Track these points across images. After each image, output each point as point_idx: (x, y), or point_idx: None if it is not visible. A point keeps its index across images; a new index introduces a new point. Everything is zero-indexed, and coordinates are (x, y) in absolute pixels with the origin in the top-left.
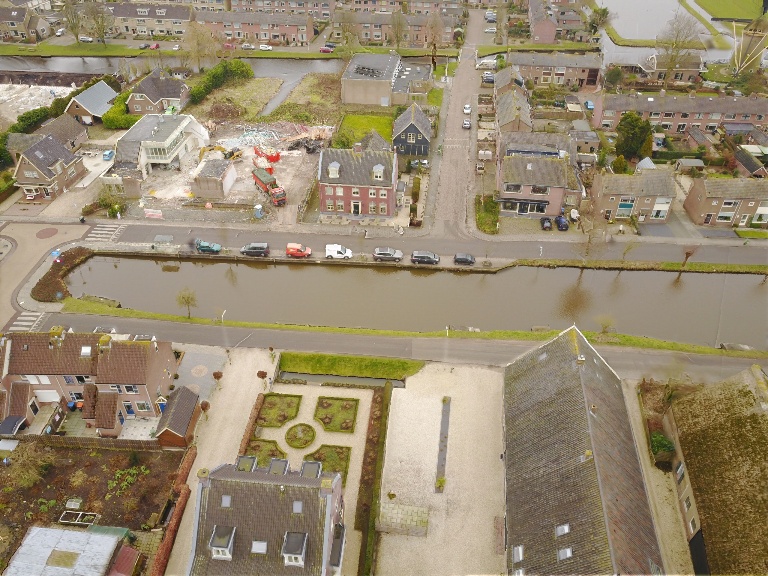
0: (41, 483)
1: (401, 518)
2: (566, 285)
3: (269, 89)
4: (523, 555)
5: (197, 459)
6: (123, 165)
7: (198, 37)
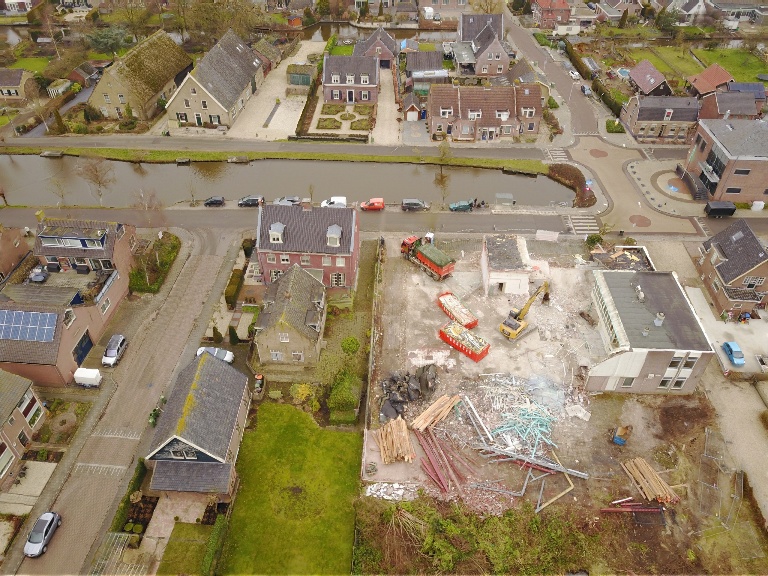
0: None
1: None
2: None
3: None
4: None
5: None
6: None
7: None
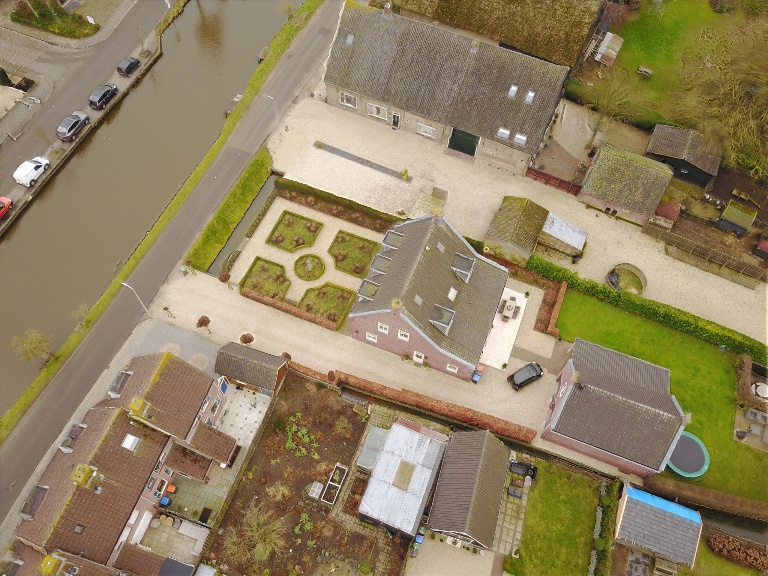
0: None
1: (424, 212)
2: (194, 23)
3: None
4: (508, 130)
5: None
6: None
7: None
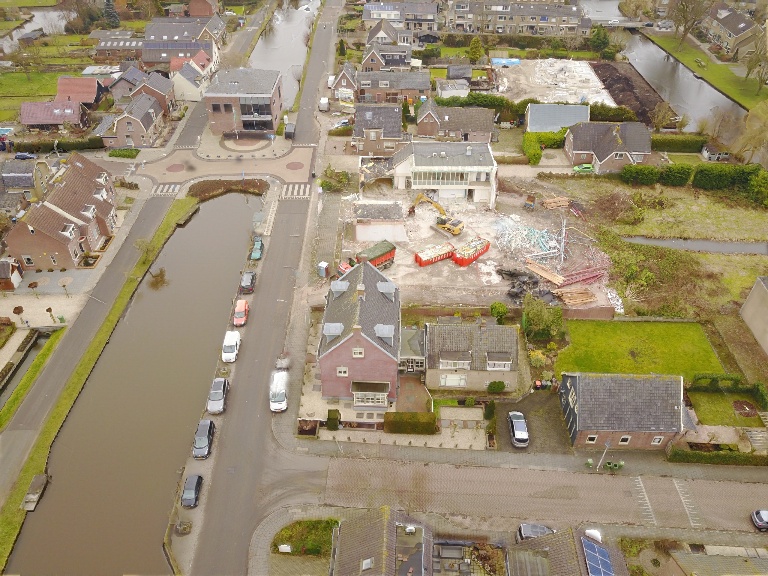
0: None
1: None
2: None
3: (739, 231)
4: None
5: None
6: (390, 163)
7: (767, 122)
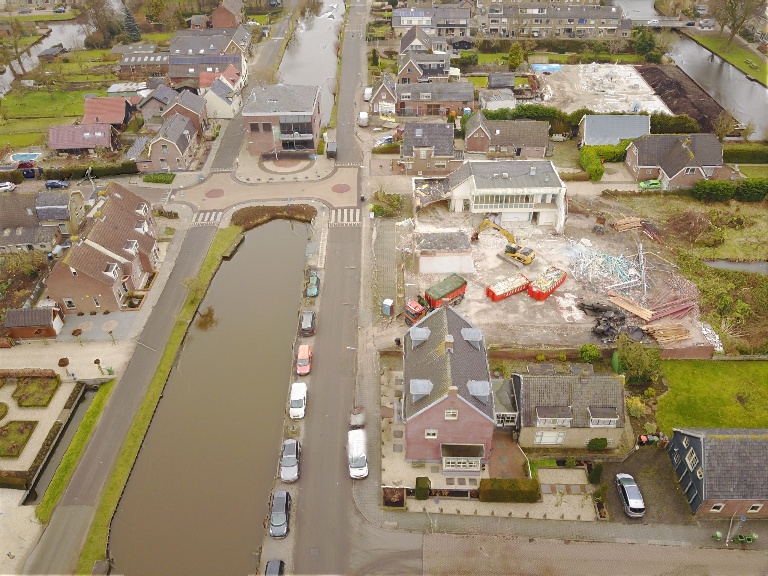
0: (28, 277)
1: None
2: None
3: None
4: None
5: (6, 349)
6: (446, 184)
7: None
